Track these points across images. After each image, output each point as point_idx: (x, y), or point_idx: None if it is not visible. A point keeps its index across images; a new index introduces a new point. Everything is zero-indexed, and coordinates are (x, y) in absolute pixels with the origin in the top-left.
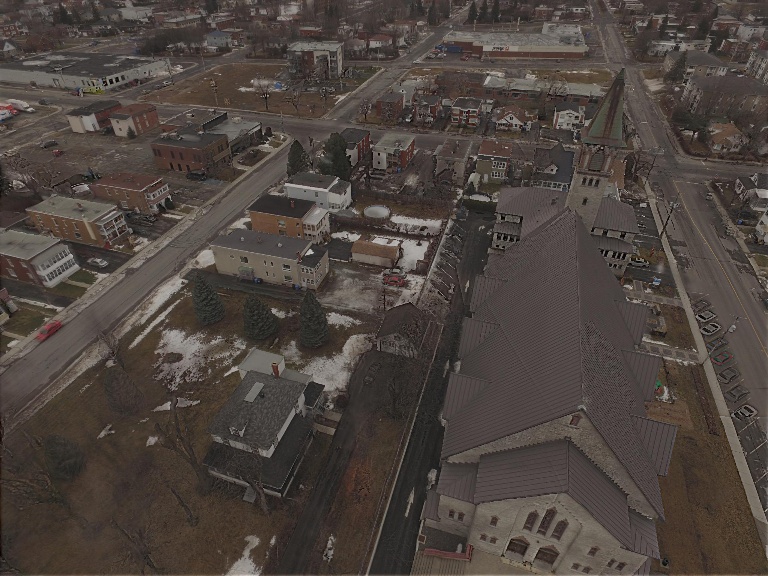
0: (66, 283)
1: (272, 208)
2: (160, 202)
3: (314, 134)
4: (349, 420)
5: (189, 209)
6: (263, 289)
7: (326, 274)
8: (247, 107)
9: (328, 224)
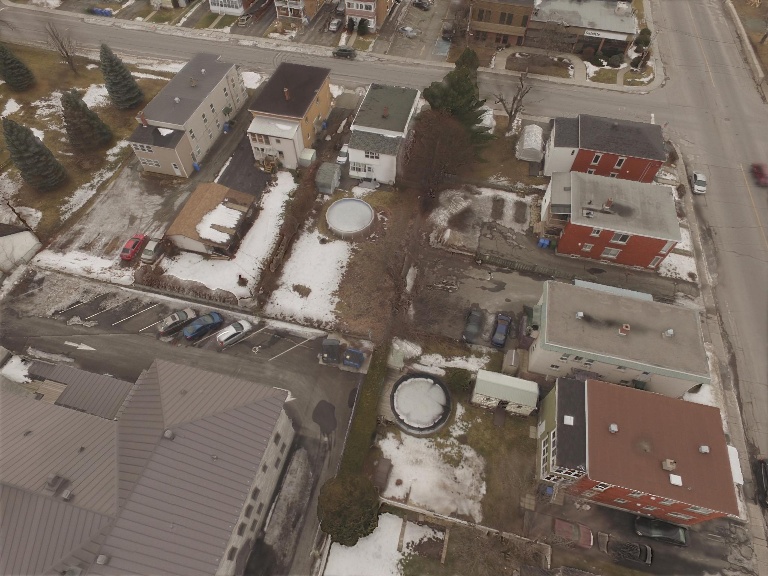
0: (218, 16)
1: (288, 82)
2: (356, 18)
3: (684, 112)
4: None
5: (362, 46)
6: None
7: (177, 175)
8: (759, 24)
9: (294, 157)
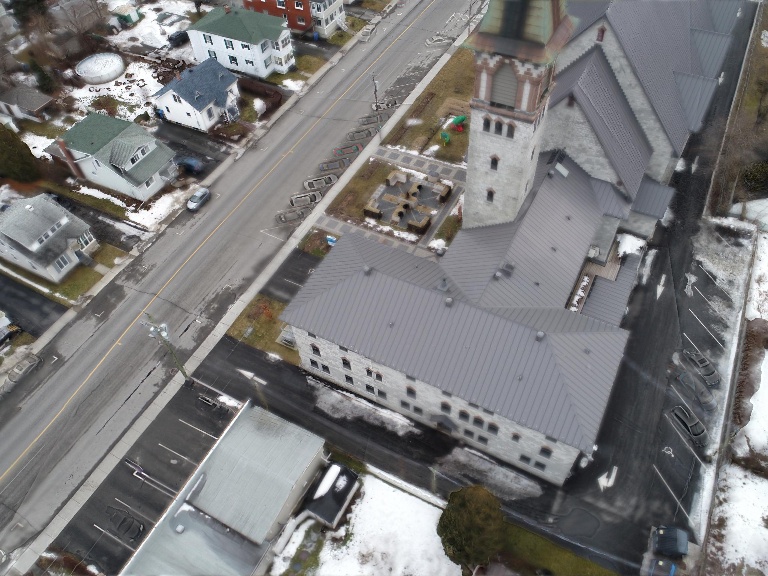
0: None
1: None
2: None
3: None
4: None
5: None
6: None
7: None
8: None
9: None
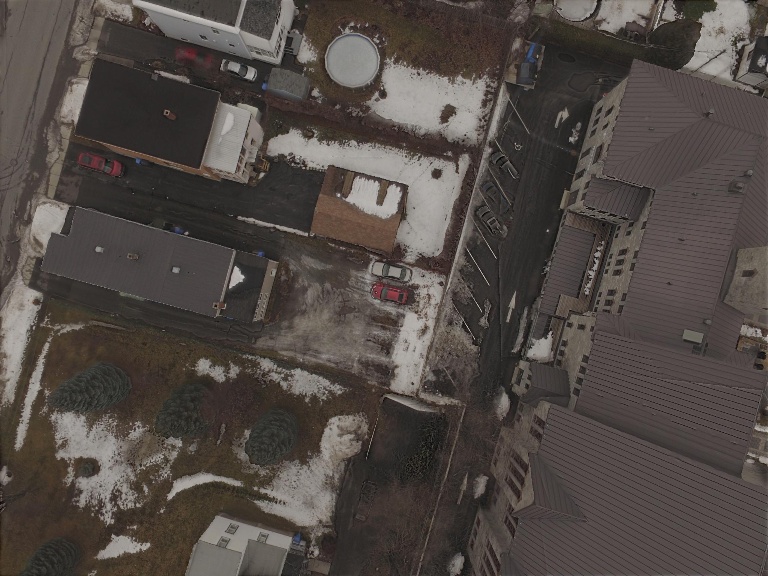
0: None
1: (128, 122)
2: None
3: None
4: (340, 571)
5: None
6: (175, 316)
7: (274, 276)
8: None
9: (257, 126)
